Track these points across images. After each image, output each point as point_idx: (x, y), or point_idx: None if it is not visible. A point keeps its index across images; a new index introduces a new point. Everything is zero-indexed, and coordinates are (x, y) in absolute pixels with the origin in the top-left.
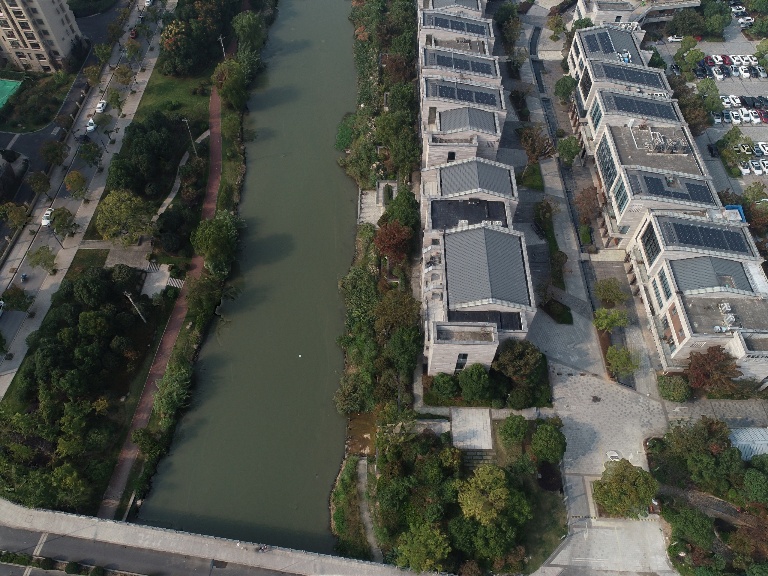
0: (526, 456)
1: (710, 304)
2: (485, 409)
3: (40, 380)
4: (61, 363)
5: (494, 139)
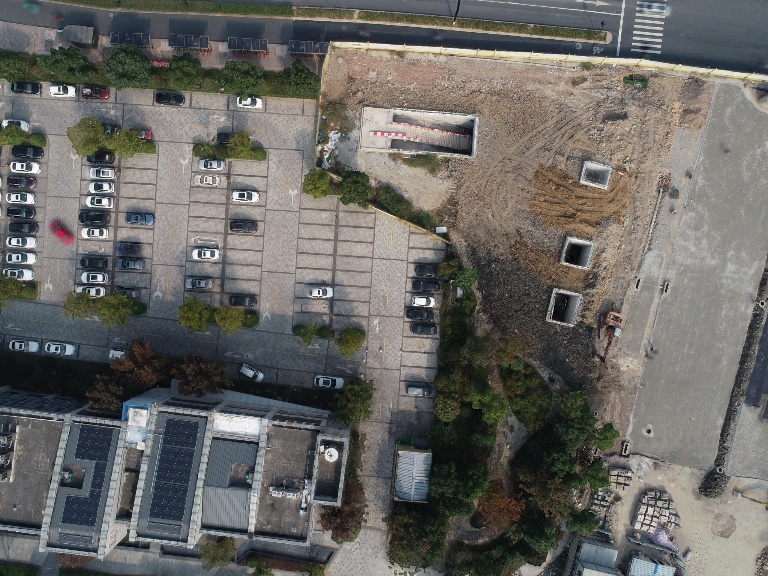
0: None
1: (268, 502)
2: None
3: None
4: None
5: None
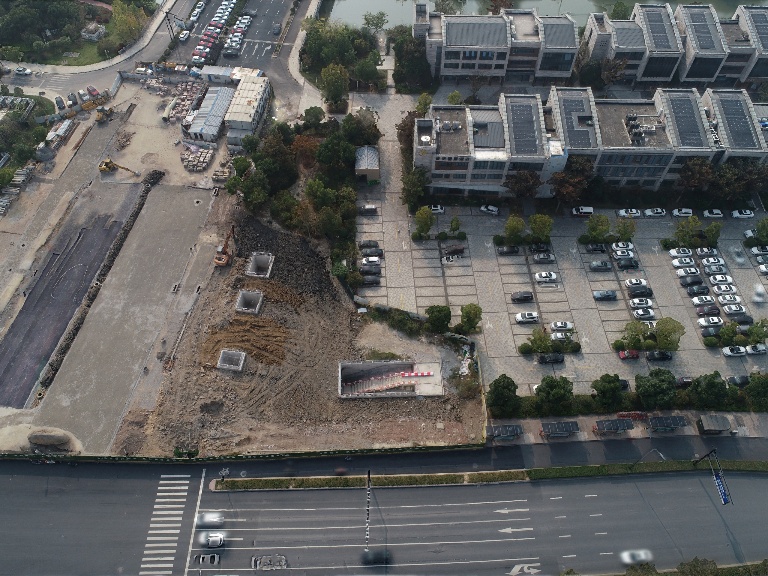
0: None
1: (461, 122)
2: None
3: None
4: None
5: None
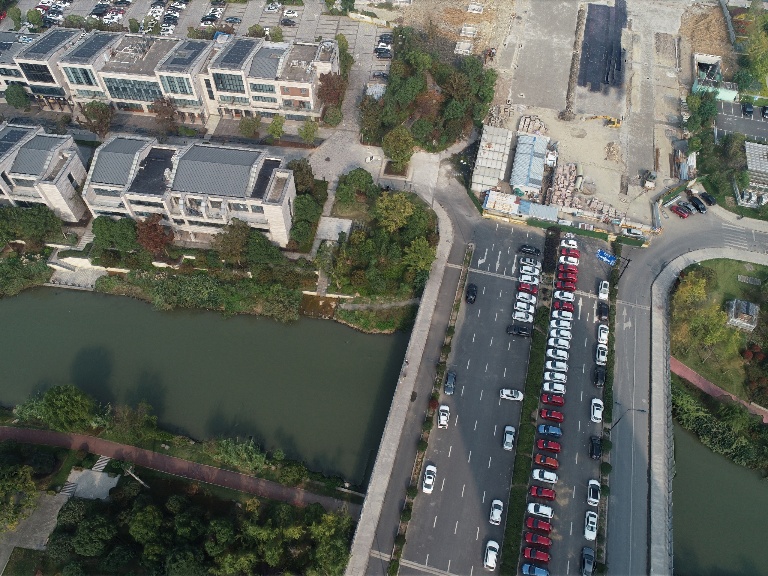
0: (370, 186)
1: (289, 70)
2: (321, 219)
3: (208, 571)
4: (193, 548)
5: (71, 142)
